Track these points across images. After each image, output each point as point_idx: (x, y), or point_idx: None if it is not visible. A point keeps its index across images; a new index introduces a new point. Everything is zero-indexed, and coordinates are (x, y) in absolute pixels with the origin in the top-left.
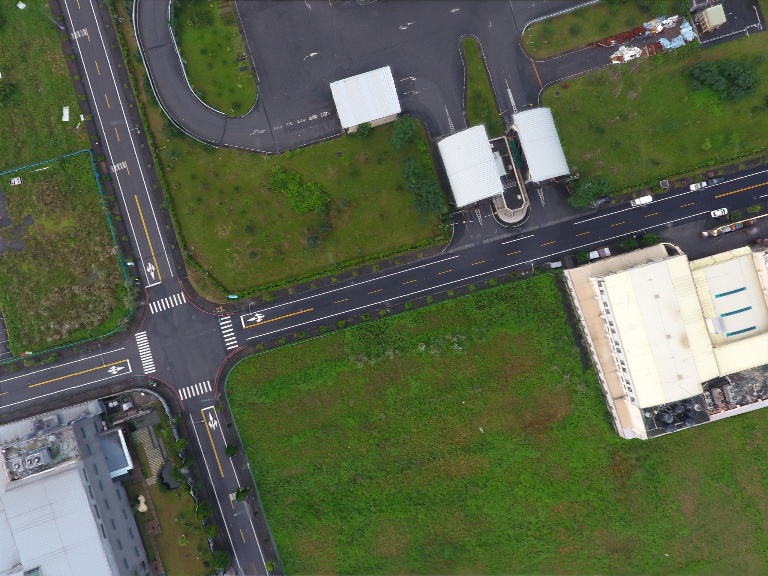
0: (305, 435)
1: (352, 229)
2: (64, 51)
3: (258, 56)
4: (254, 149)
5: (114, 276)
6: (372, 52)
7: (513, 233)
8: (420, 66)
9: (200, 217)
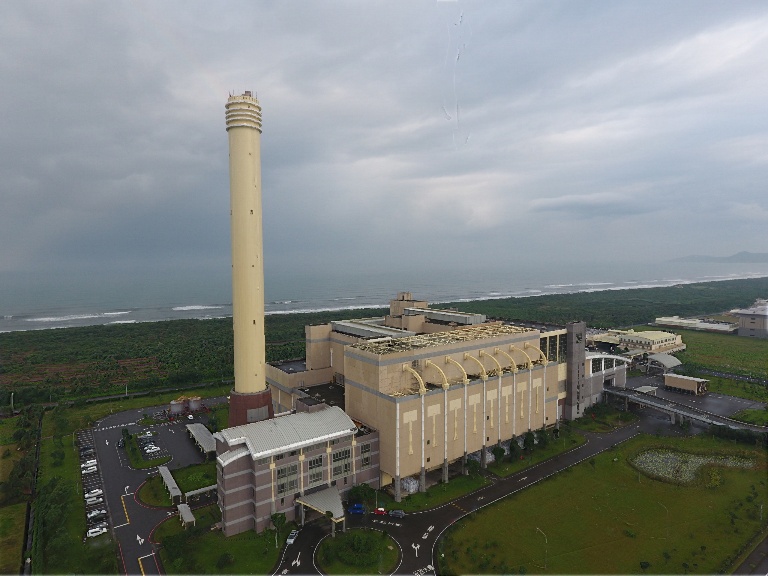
0: None
1: None
2: None
3: None
4: None
5: None
6: (659, 391)
7: None
8: None
9: None
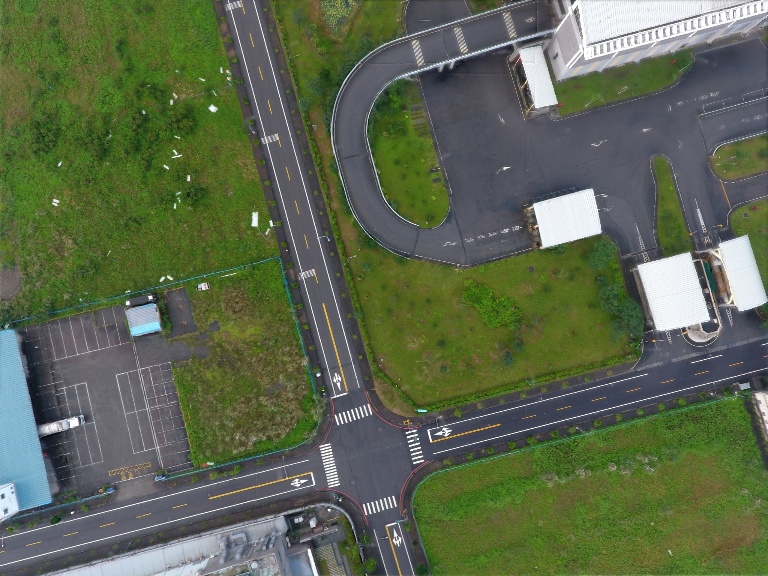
0: (492, 554)
1: (542, 344)
2: (255, 156)
3: (451, 168)
4: (445, 261)
5: (301, 387)
6: (564, 168)
7: (701, 352)
8: (612, 183)
9: (389, 328)
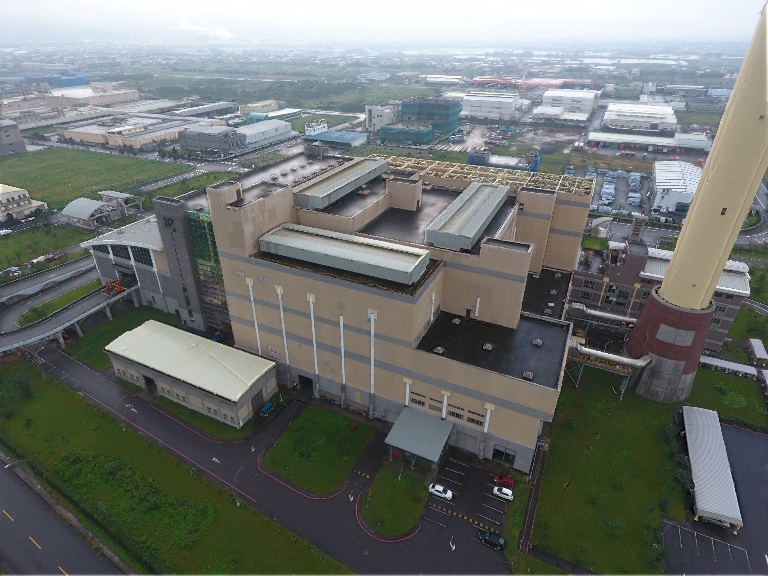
0: None
1: None
2: None
3: None
4: None
5: None
6: None
7: None
8: None
9: None
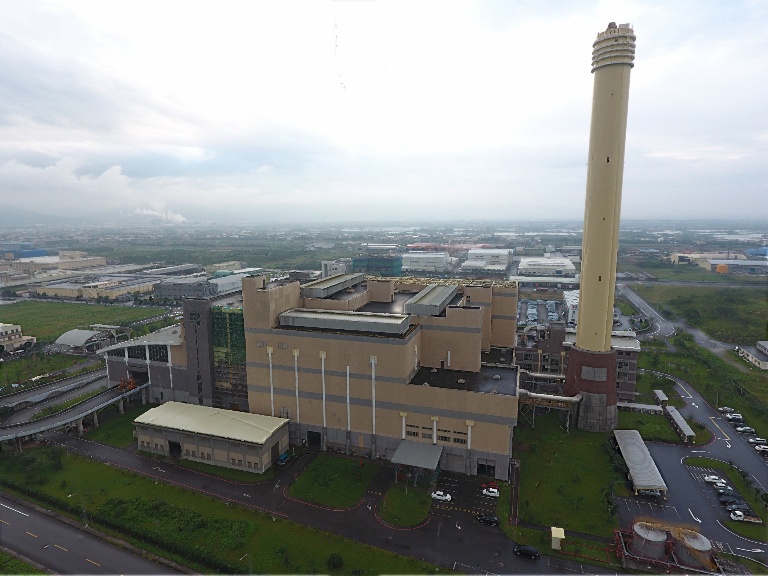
0: None
1: None
2: None
3: None
4: None
5: None
6: None
7: None
8: None
9: None
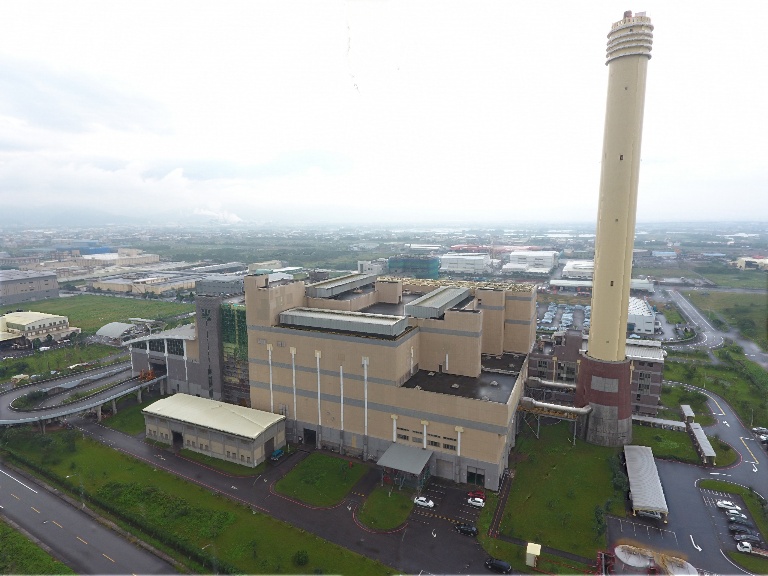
0: None
1: None
2: None
3: None
4: None
5: None
6: None
7: None
8: None
9: None
